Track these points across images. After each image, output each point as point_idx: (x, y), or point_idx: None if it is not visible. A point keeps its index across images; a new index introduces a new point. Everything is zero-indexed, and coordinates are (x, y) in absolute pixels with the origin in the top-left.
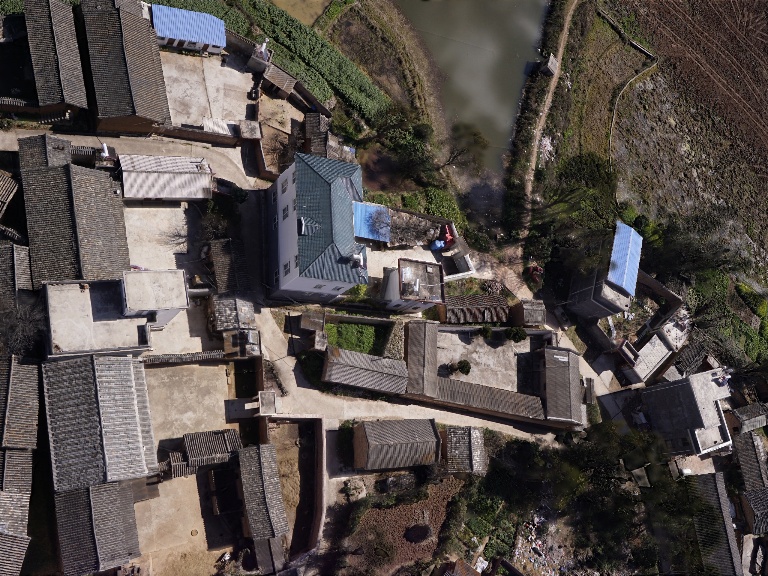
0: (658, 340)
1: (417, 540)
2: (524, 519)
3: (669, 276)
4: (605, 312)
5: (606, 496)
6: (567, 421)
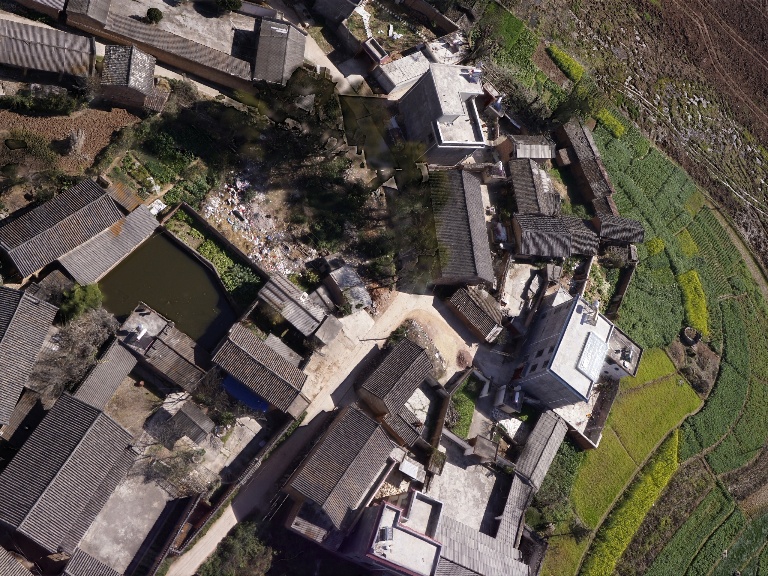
0: (423, 56)
1: (62, 150)
2: (219, 175)
3: (444, 2)
4: (347, 6)
5: (337, 184)
6: (275, 83)
